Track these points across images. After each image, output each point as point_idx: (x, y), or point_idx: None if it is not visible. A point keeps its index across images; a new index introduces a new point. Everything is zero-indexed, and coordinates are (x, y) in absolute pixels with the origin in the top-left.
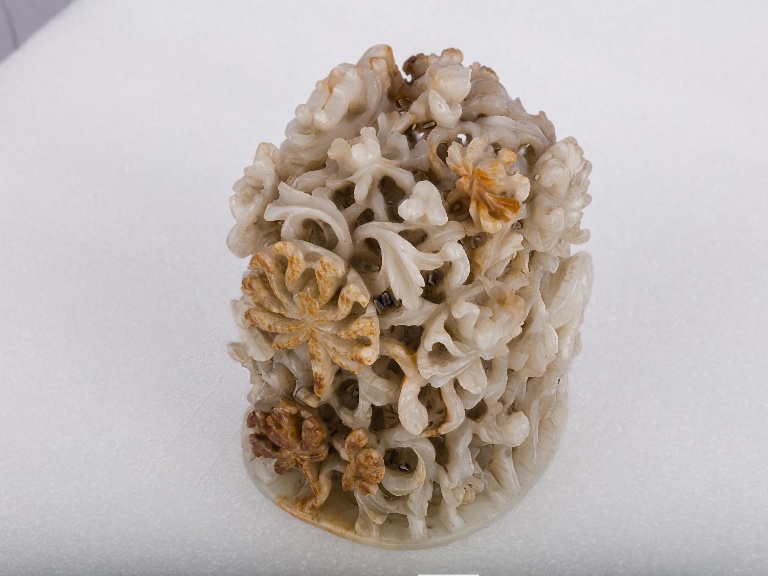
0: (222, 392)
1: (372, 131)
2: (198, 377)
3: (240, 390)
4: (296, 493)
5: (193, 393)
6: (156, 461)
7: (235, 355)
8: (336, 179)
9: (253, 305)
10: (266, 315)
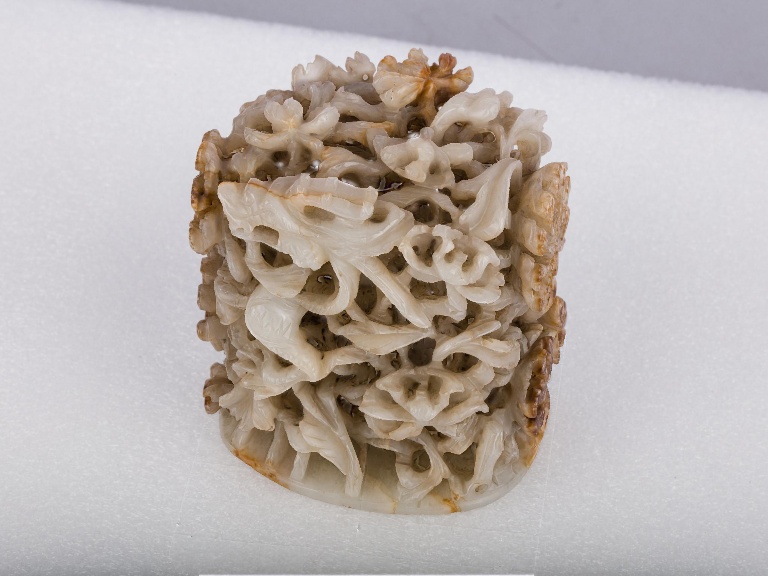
0: (389, 549)
1: (393, 145)
2: (375, 572)
3: (380, 536)
4: (519, 449)
5: (399, 570)
6: (509, 570)
7: (487, 406)
8: (441, 183)
9: (534, 297)
10: (541, 288)
